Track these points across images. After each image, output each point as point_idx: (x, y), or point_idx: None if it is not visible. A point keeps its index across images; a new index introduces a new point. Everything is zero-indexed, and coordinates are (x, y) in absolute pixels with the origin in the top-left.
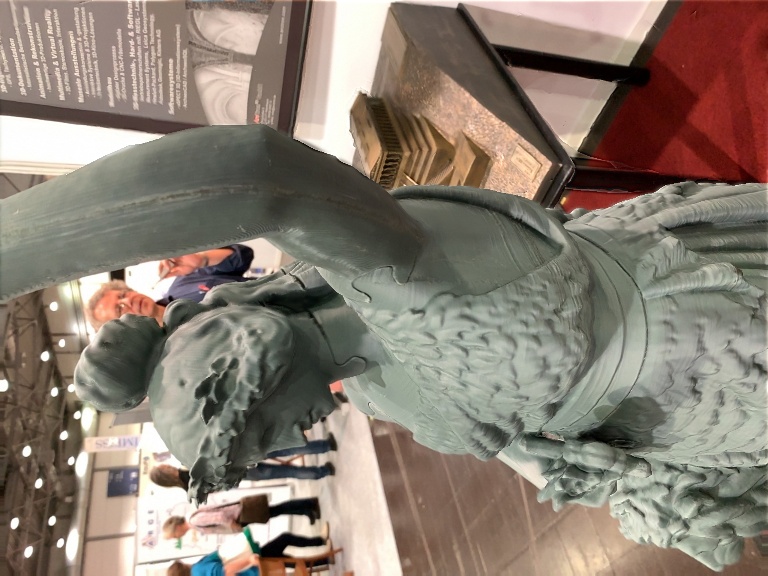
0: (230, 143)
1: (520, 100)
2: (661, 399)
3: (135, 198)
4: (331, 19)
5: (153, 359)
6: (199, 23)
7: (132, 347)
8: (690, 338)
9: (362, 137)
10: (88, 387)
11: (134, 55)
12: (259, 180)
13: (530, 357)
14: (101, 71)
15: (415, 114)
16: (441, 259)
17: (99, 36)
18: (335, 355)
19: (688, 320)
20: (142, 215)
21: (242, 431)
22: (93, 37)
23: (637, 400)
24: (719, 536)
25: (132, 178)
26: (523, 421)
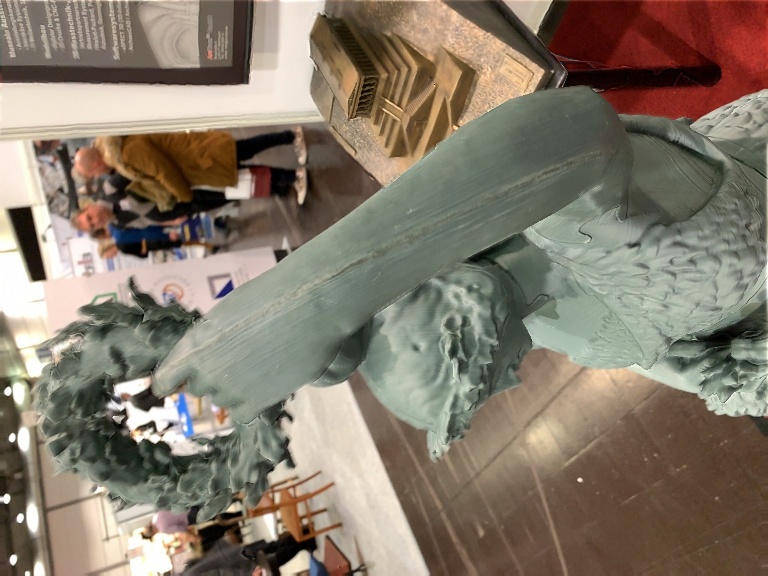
0: (577, 110)
1: (497, 7)
2: None
3: (518, 180)
4: None
5: (365, 329)
6: None
7: None
8: None
9: (331, 63)
10: None
11: None
12: (602, 144)
13: (731, 272)
14: (31, 19)
15: (385, 32)
16: (638, 191)
17: None
18: (526, 297)
19: None
20: (523, 196)
21: None
22: None
23: None
24: None
25: (508, 160)
26: None
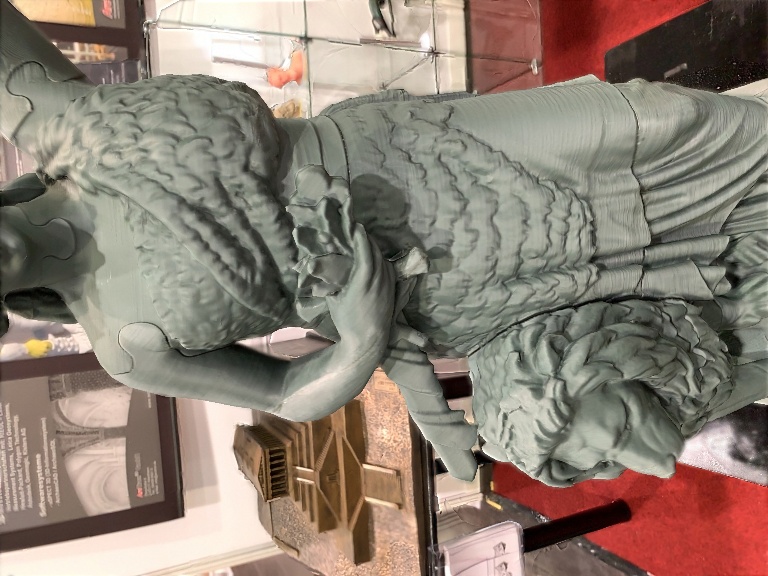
0: None
1: None
2: (383, 173)
3: None
4: None
5: None
6: (65, 411)
7: None
8: (374, 115)
9: (246, 457)
10: None
11: None
12: None
13: (194, 99)
14: None
15: None
16: None
17: None
18: (29, 215)
19: (368, 109)
20: None
21: None
22: None
23: (361, 180)
24: (599, 372)
25: None
26: (253, 225)
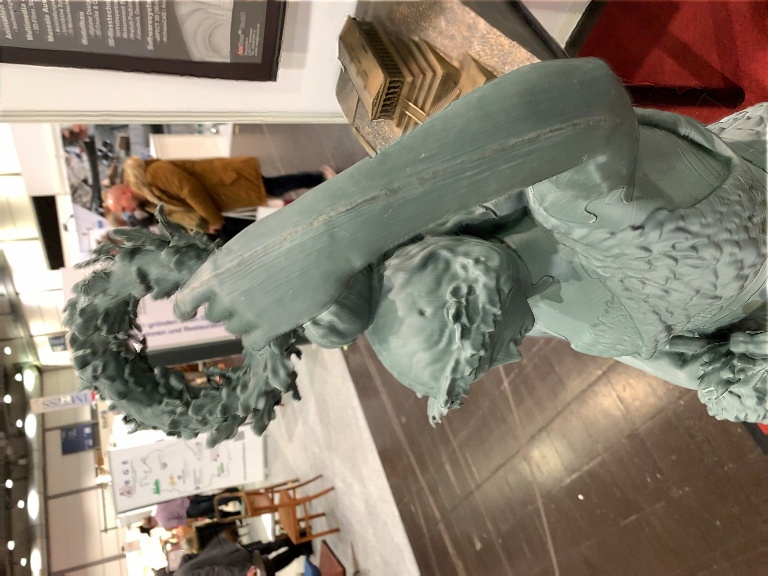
0: (585, 77)
1: (524, 17)
2: None
3: (524, 135)
4: None
5: (375, 294)
6: None
7: (359, 284)
8: None
9: (358, 64)
10: (325, 326)
11: None
12: (607, 111)
13: (732, 261)
14: (72, 5)
15: (413, 37)
16: (646, 178)
17: None
18: (532, 276)
19: None
20: (528, 151)
21: None
22: None
23: None
24: None
25: (517, 116)
26: None
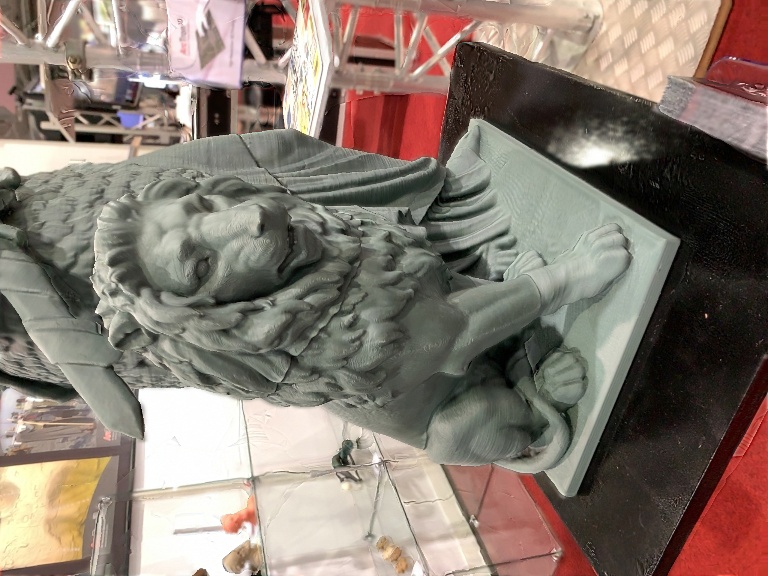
0: None
1: None
2: None
3: None
4: None
5: None
6: None
7: None
8: None
9: None
10: None
11: None
12: None
13: None
14: None
15: None
16: None
17: None
18: None
19: None
20: None
21: None
22: None
23: None
24: None
25: None
26: None
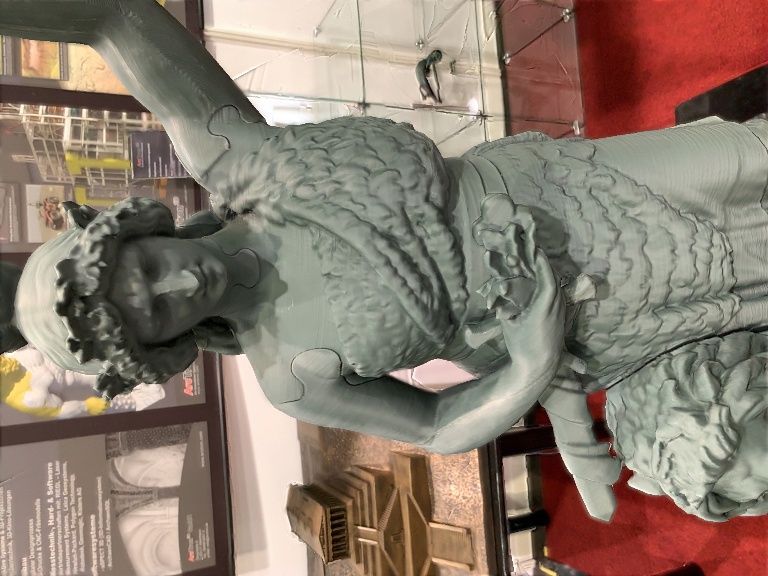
0: None
1: None
2: (543, 205)
3: None
4: (247, 435)
5: None
6: (120, 469)
7: None
8: (526, 153)
9: (303, 517)
10: None
11: (53, 523)
12: None
13: (380, 136)
14: (15, 554)
15: (345, 469)
16: None
17: (16, 513)
18: None
19: (517, 148)
20: None
21: (116, 232)
22: (9, 516)
23: None
24: (763, 397)
25: None
26: (430, 253)
